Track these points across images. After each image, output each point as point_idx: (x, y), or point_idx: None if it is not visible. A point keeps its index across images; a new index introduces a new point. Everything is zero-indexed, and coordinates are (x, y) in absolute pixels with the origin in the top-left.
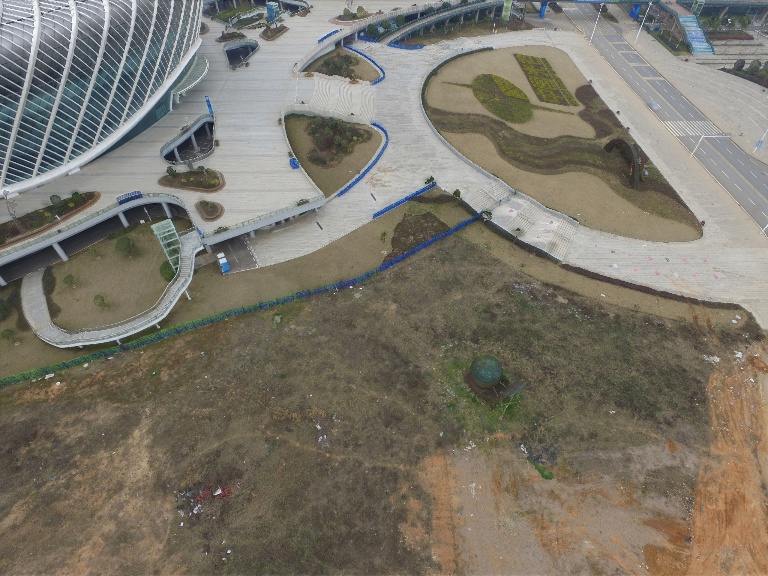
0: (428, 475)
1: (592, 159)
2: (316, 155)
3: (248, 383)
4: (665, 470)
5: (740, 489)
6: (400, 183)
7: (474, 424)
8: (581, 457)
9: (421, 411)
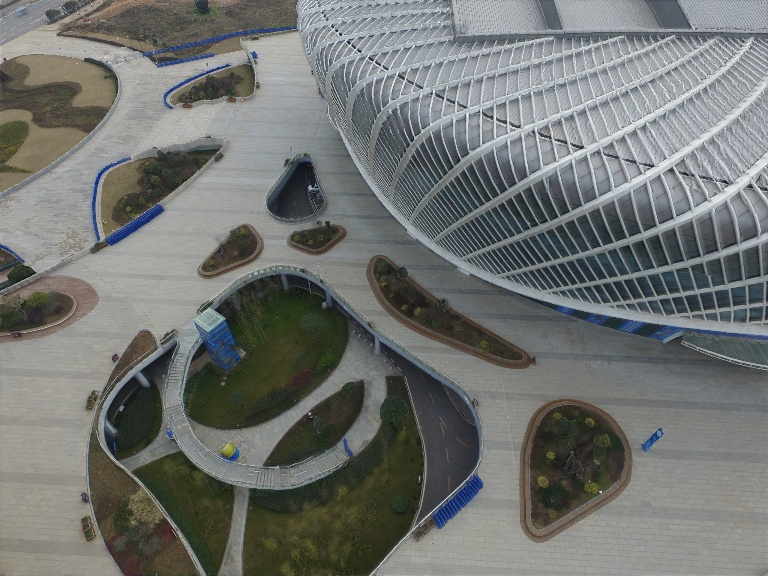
0: (237, 2)
1: (3, 95)
2: (236, 75)
3: (294, 16)
4: (162, 2)
5: (144, 0)
6: (183, 70)
7: (215, 7)
8: (185, 4)
9: (231, 8)
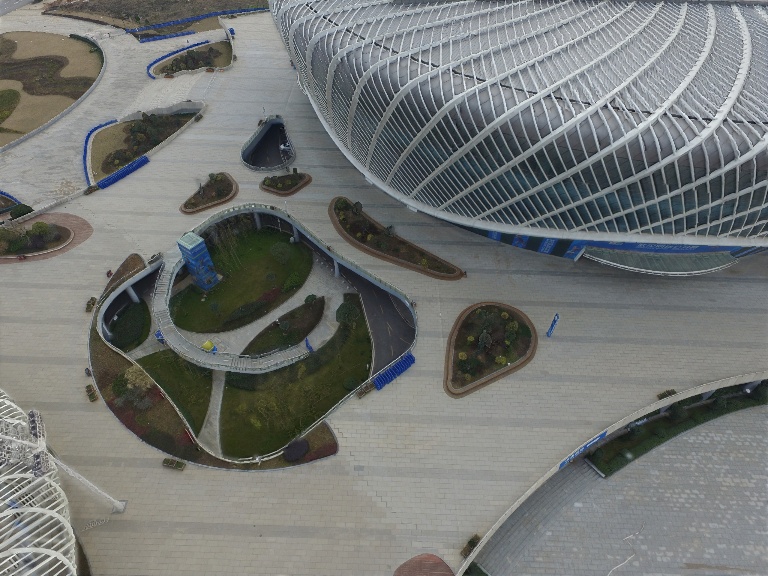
0: None
1: None
2: (215, 50)
3: None
4: None
5: None
6: (164, 45)
7: None
8: None
9: None
